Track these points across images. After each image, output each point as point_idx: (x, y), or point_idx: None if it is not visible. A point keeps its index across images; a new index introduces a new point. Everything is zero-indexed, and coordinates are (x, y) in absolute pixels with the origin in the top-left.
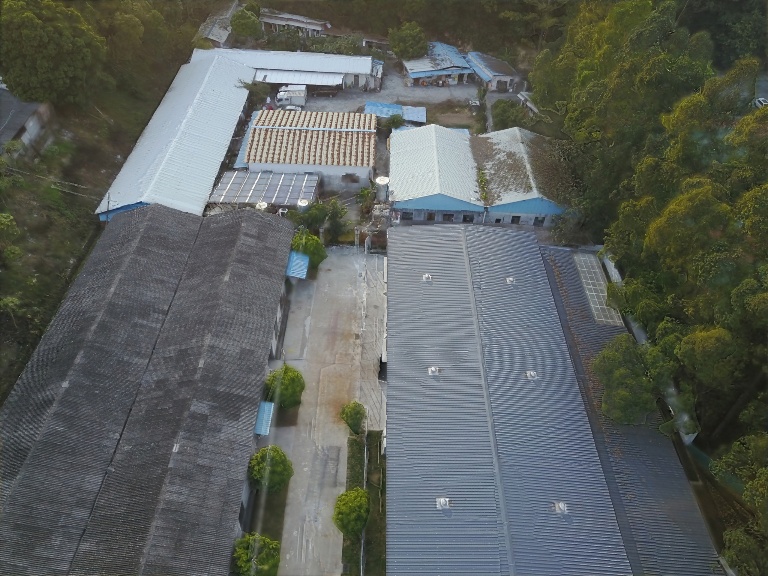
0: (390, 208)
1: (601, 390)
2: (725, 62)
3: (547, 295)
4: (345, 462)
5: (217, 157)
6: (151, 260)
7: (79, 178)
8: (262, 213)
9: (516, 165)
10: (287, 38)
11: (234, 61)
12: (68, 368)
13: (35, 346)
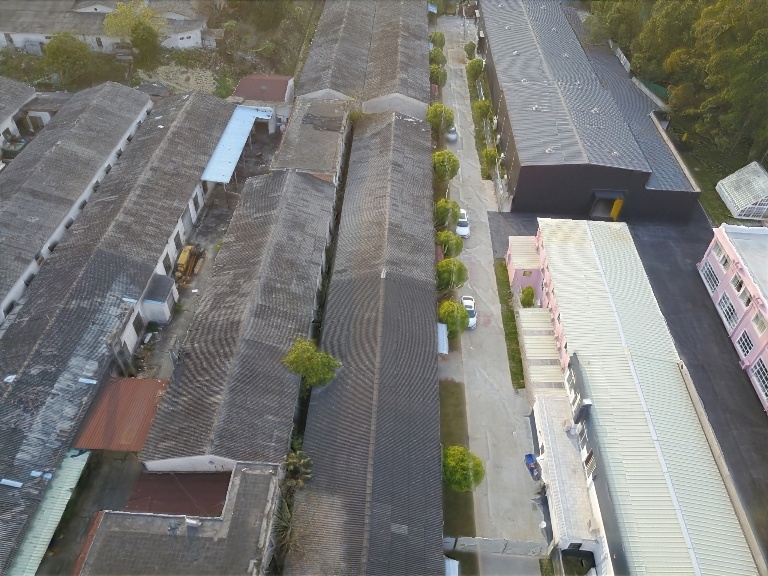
0: None
1: (586, 44)
2: None
3: (562, 13)
4: (465, 72)
5: None
6: None
7: None
8: None
9: None
10: None
11: None
12: (341, 22)
13: (304, 38)
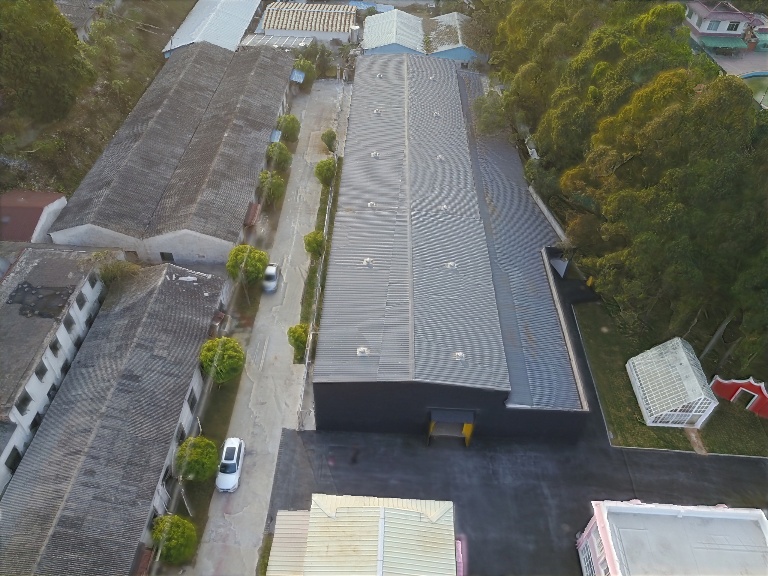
0: (361, 51)
1: None
2: None
3: (455, 86)
4: None
5: (243, 26)
6: (203, 67)
7: (148, 34)
8: (274, 48)
9: (451, 31)
10: None
11: None
12: (160, 105)
13: None
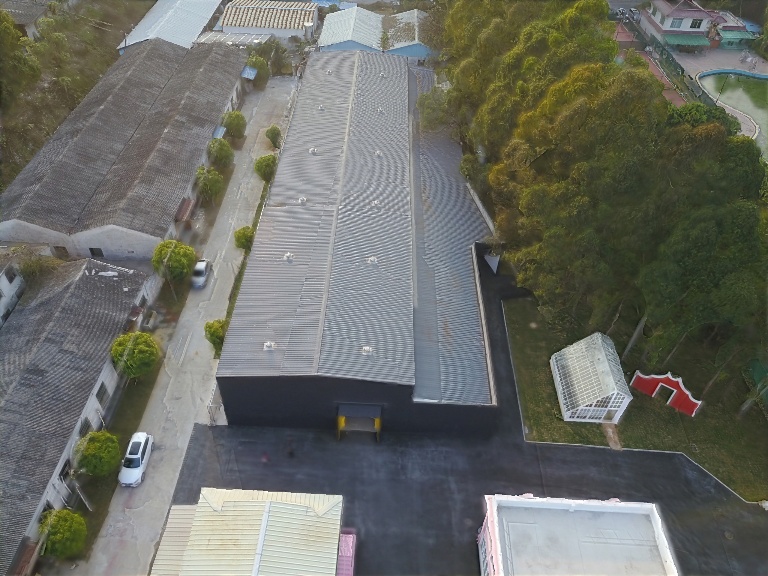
0: (316, 47)
1: None
2: None
3: (404, 82)
4: None
5: (201, 24)
6: (154, 64)
7: (105, 31)
8: (228, 45)
9: (409, 29)
10: None
11: None
12: (103, 101)
13: None
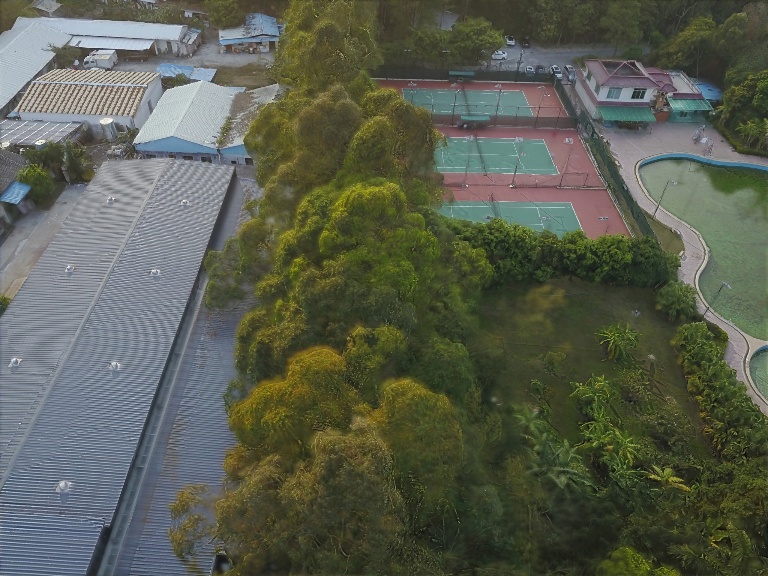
0: (123, 148)
1: None
2: (535, 34)
3: (212, 214)
4: None
5: None
6: None
7: None
8: None
9: None
10: (121, 10)
11: (51, 28)
12: None
13: None
